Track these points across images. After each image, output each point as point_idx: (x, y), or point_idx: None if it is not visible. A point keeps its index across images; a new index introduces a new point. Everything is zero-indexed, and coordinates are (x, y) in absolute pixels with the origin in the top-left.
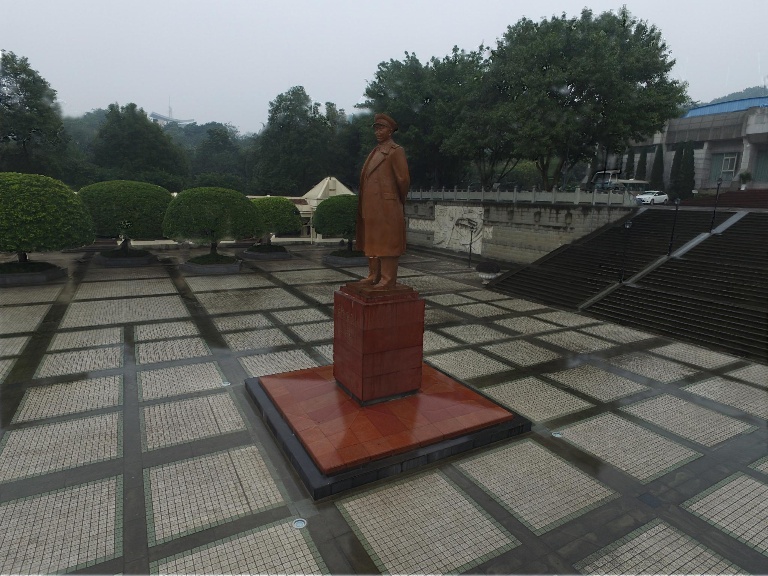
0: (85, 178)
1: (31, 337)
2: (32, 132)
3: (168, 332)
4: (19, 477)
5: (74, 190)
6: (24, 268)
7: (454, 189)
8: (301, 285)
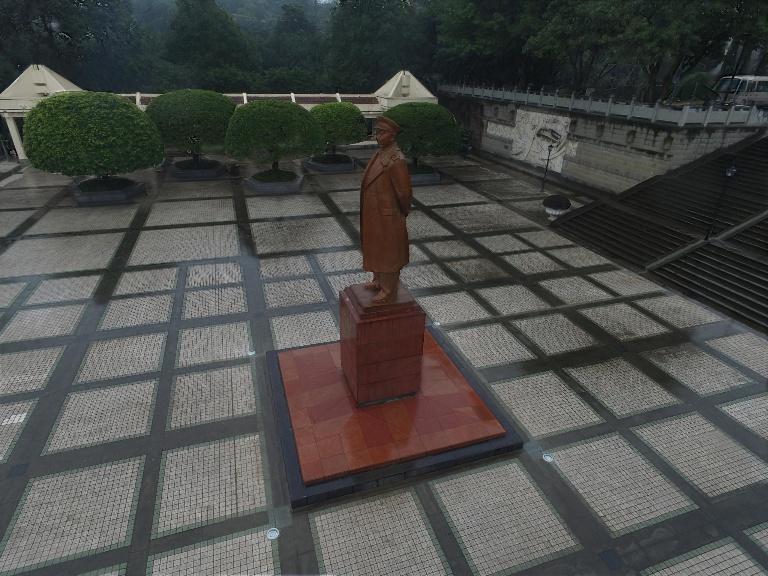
0: (160, 77)
1: (103, 276)
2: (108, 28)
3: (216, 277)
4: (70, 447)
5: (151, 91)
6: (106, 186)
7: (540, 92)
8: (354, 214)
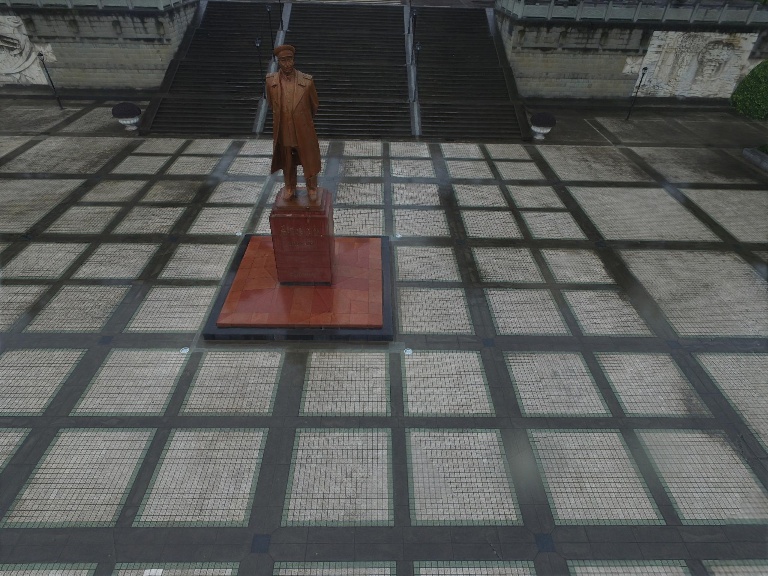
0: None
1: None
2: None
3: None
4: (249, 498)
5: None
6: None
7: None
8: None
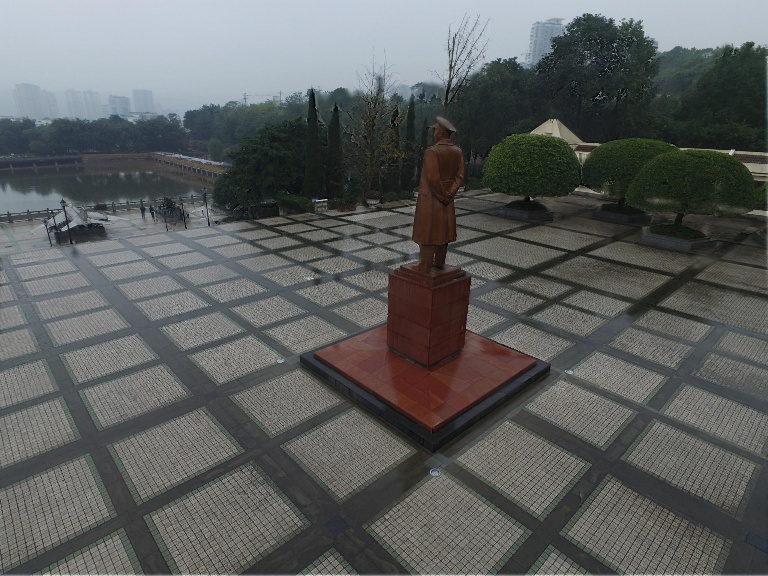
0: None
1: None
2: None
3: (484, 272)
4: None
5: None
6: (521, 206)
7: None
8: (705, 283)
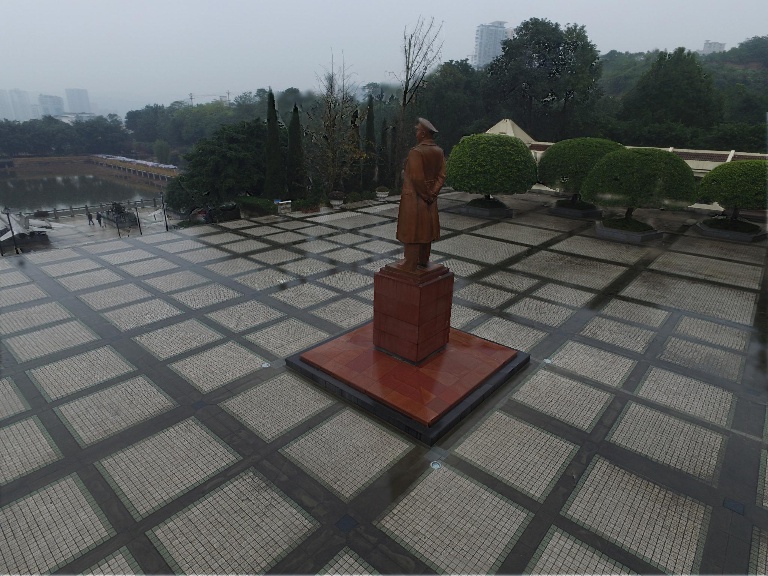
0: (599, 131)
1: (403, 247)
2: None
3: (455, 269)
4: None
5: None
6: (482, 204)
7: None
8: (657, 272)
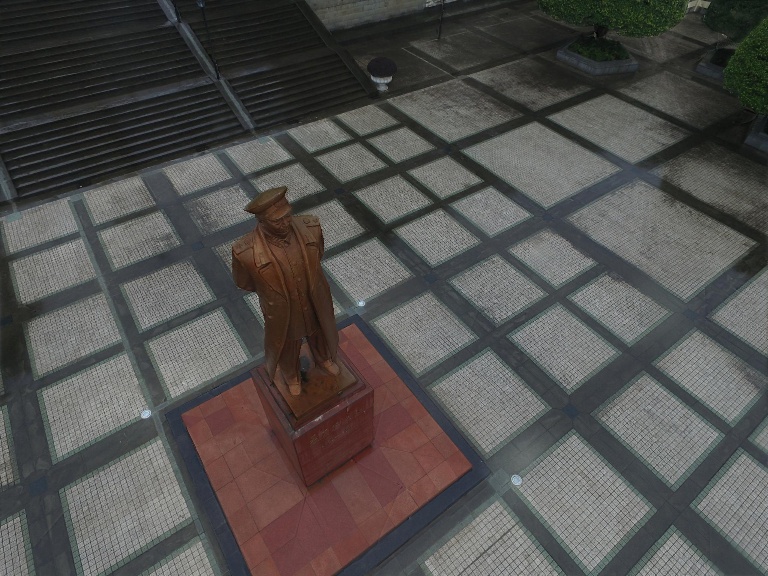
0: None
1: None
2: None
3: None
4: None
5: None
6: None
7: None
8: None
